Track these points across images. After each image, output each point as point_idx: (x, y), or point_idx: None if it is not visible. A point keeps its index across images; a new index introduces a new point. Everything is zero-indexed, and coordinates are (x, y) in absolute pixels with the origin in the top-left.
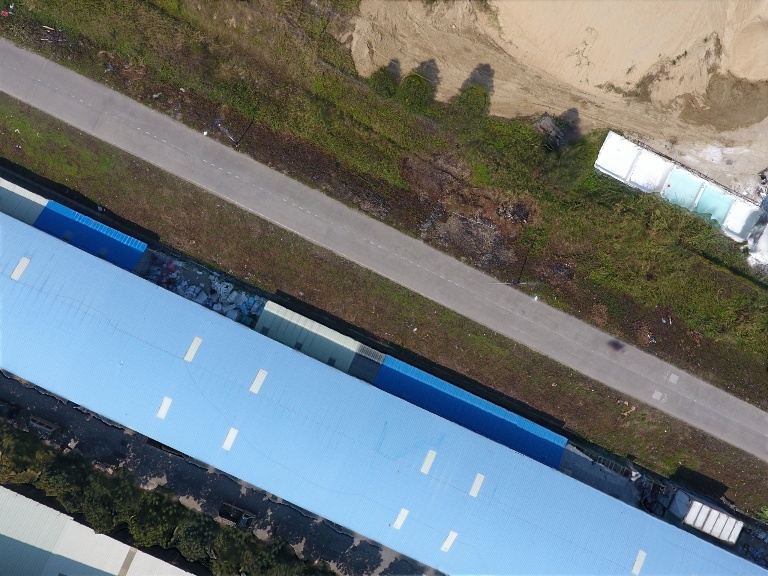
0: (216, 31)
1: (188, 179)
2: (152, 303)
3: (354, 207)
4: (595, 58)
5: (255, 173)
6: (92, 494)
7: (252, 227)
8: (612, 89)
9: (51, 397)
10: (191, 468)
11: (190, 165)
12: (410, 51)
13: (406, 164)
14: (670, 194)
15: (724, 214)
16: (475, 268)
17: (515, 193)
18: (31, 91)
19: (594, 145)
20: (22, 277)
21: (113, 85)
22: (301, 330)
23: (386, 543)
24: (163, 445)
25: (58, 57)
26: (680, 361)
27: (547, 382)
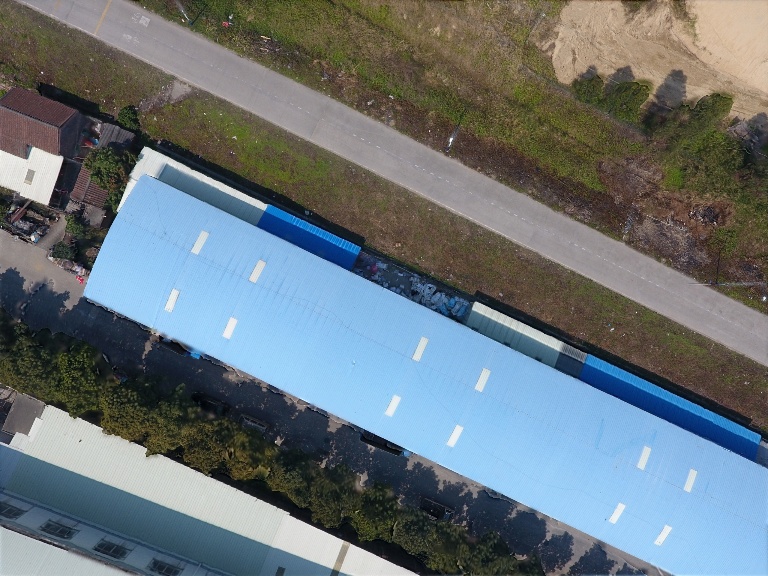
0: (419, 39)
1: (401, 184)
2: (380, 304)
3: (559, 210)
4: None
5: (464, 178)
6: (320, 489)
7: (461, 230)
8: None
9: (258, 396)
10: (391, 465)
11: (403, 170)
12: (607, 58)
13: (601, 168)
14: None
15: None
16: (675, 269)
17: (713, 196)
18: (252, 99)
19: None
20: (259, 279)
21: (330, 93)
22: (508, 330)
23: (600, 537)
24: (388, 442)
25: (278, 66)
26: None
27: (740, 380)
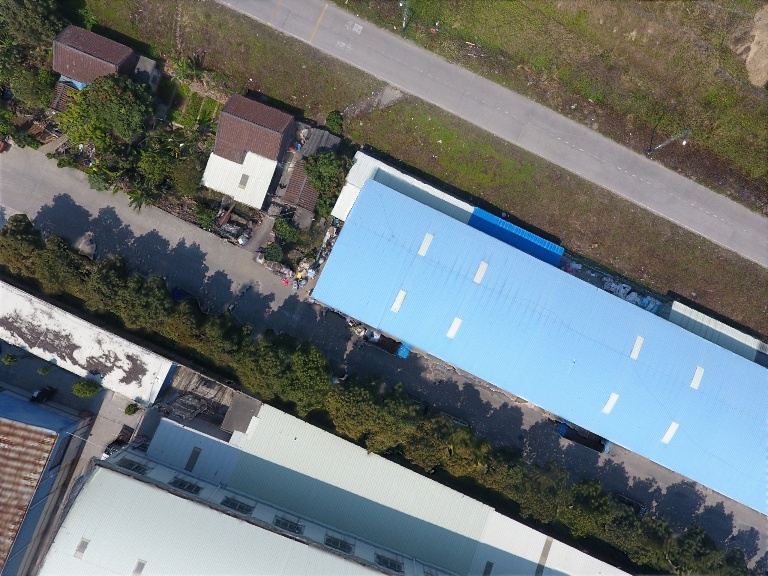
0: (612, 44)
1: (604, 186)
2: (596, 304)
3: (757, 211)
4: None
5: (665, 179)
6: (536, 485)
7: (662, 231)
8: None
9: (455, 394)
10: (582, 461)
11: (605, 172)
12: None
13: None
14: None
15: None
16: None
17: None
18: (461, 104)
19: None
20: (483, 280)
21: (535, 97)
22: (707, 329)
23: None
24: (603, 439)
25: (486, 71)
26: None
27: None
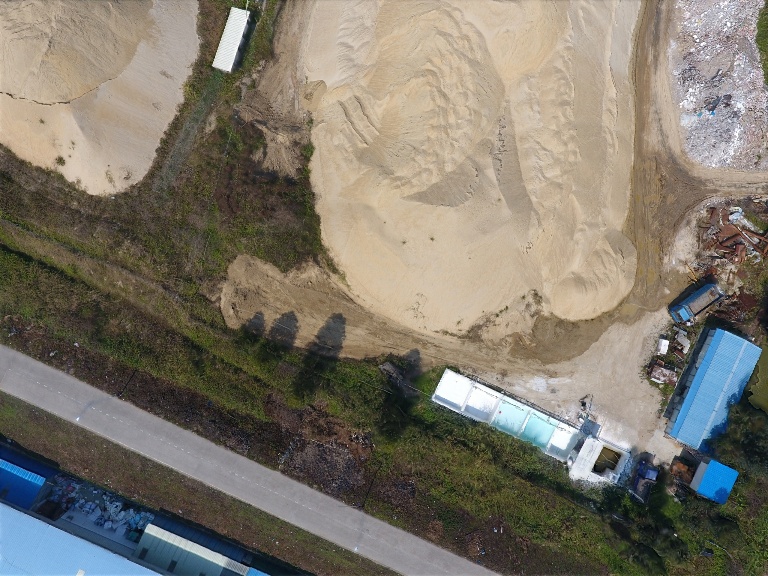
0: (107, 289)
1: (79, 424)
2: (43, 541)
3: (221, 444)
4: (428, 313)
5: (136, 417)
6: None
7: (134, 463)
8: (447, 334)
9: None
10: None
11: (81, 412)
12: (272, 305)
13: (271, 399)
14: (501, 419)
15: (549, 436)
16: (325, 494)
17: (360, 429)
18: None
19: (432, 382)
20: None
21: (16, 347)
22: (176, 549)
23: None
24: None
25: None
26: (505, 570)
27: None
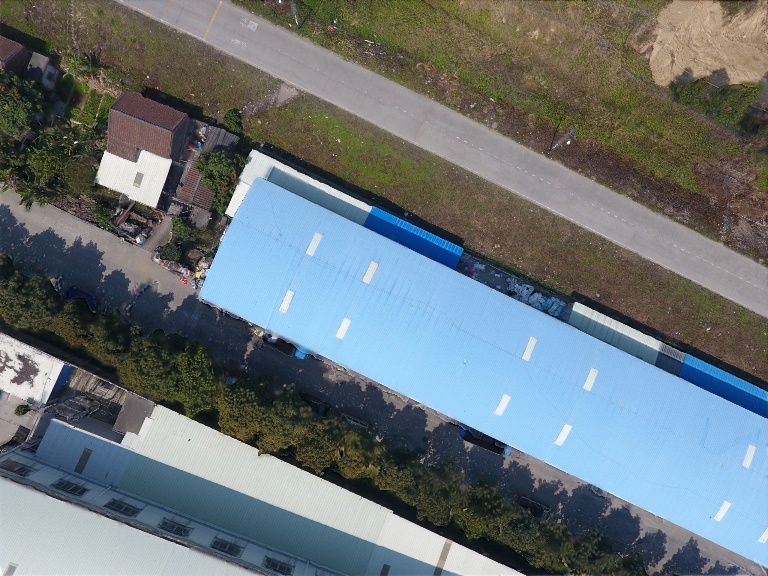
0: (516, 43)
1: (503, 185)
2: (489, 305)
3: (658, 211)
4: None
5: (566, 179)
6: (429, 488)
7: (562, 231)
8: None
9: (357, 395)
10: (487, 463)
11: (505, 172)
12: (702, 60)
13: (695, 169)
14: None
15: None
16: None
17: None
18: (358, 102)
19: None
20: (373, 281)
21: (434, 96)
22: (608, 330)
23: (704, 535)
24: (496, 441)
25: (383, 70)
26: None
27: None
